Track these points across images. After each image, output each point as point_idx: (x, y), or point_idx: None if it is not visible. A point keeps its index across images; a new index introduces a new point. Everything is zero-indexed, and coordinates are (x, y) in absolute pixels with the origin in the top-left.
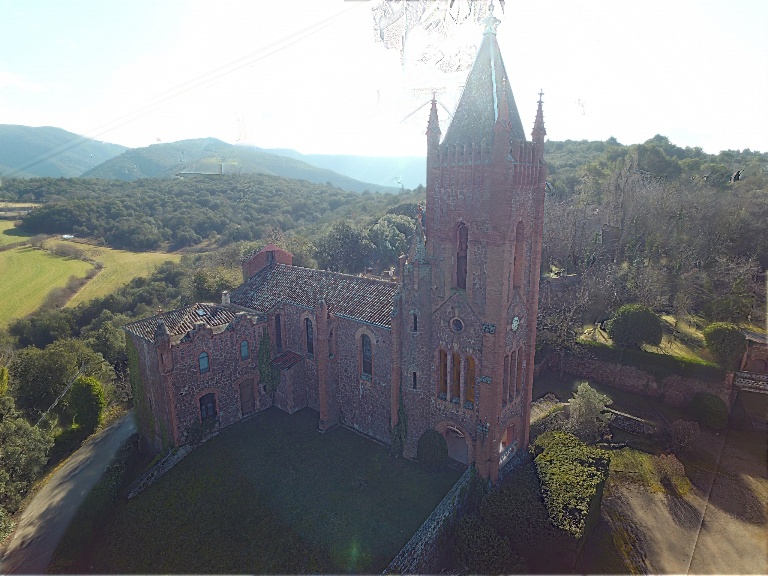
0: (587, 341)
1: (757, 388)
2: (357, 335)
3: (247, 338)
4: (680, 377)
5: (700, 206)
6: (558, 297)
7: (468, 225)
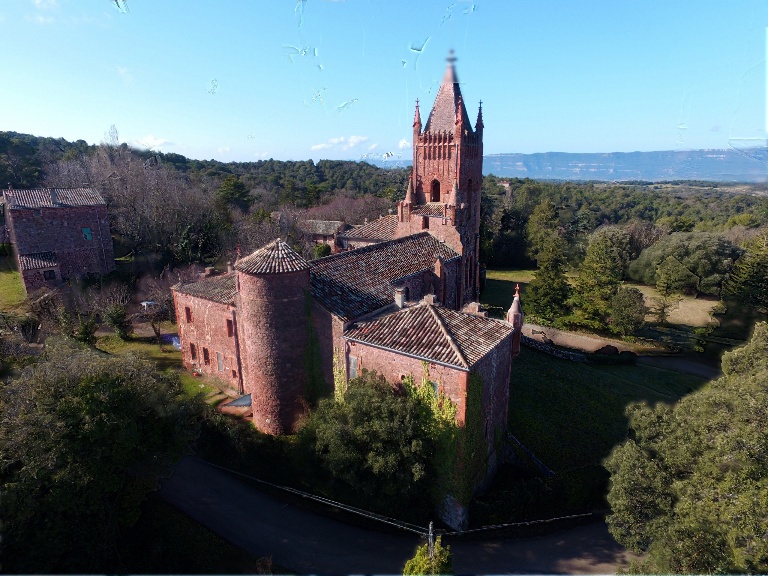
0: None
1: None
2: None
3: None
4: None
5: None
6: None
7: None
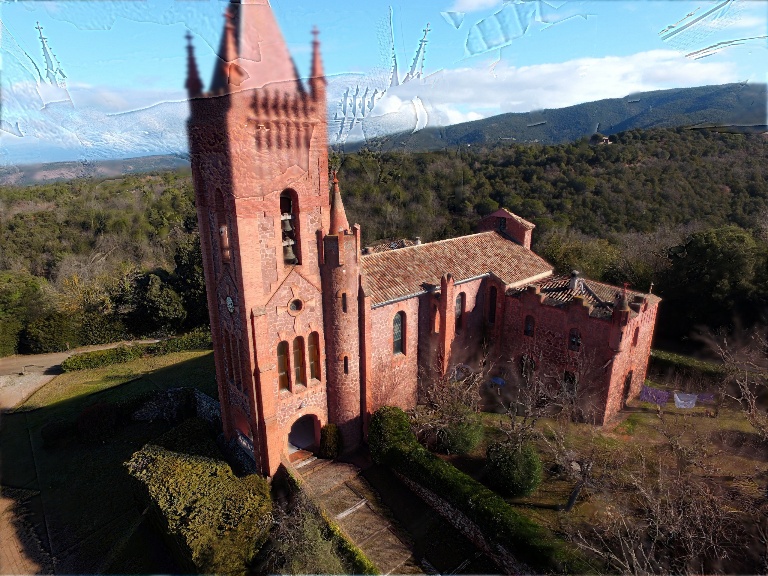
0: None
1: None
2: None
3: None
4: None
5: None
6: None
7: None
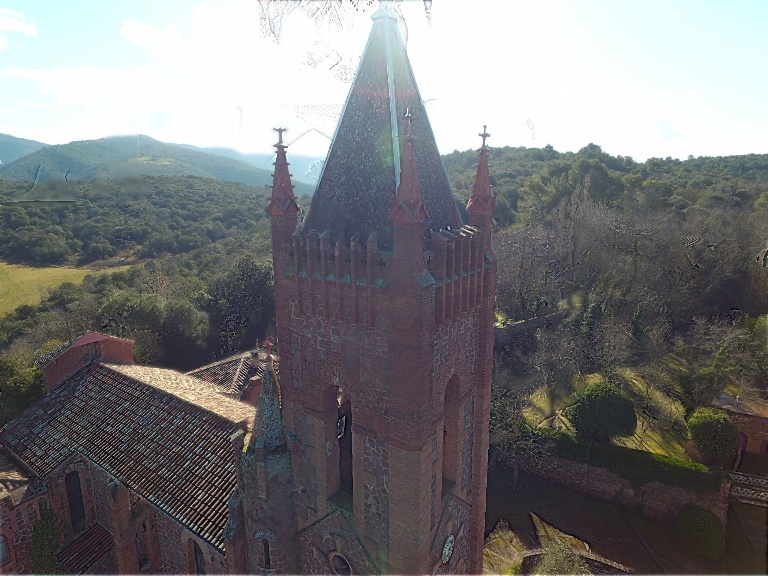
0: (545, 430)
1: (758, 500)
2: (183, 537)
3: (2, 531)
4: (663, 484)
5: (655, 236)
6: (505, 350)
7: (351, 395)
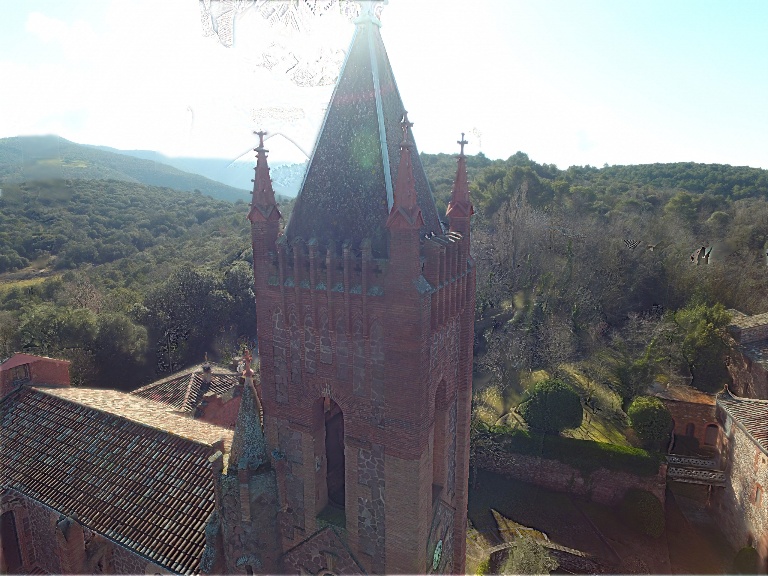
0: (500, 428)
1: (690, 478)
2: (148, 573)
3: None
4: (609, 471)
5: (586, 239)
6: None
7: (343, 407)
